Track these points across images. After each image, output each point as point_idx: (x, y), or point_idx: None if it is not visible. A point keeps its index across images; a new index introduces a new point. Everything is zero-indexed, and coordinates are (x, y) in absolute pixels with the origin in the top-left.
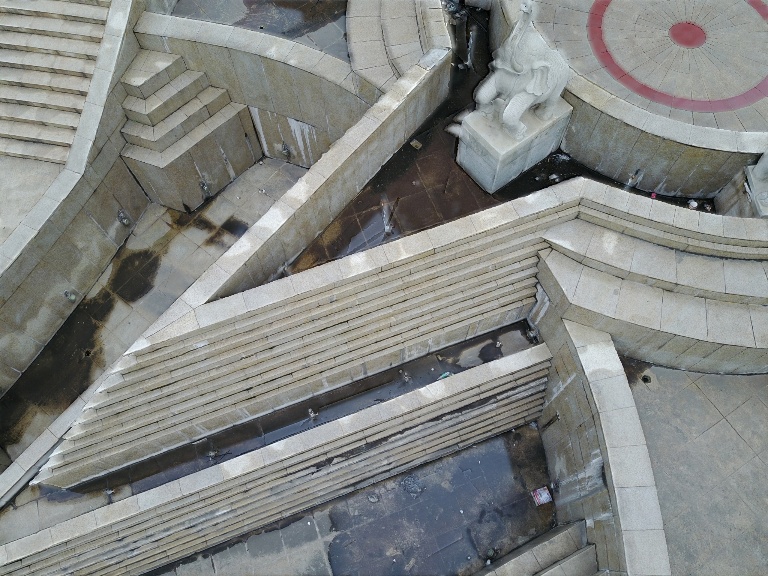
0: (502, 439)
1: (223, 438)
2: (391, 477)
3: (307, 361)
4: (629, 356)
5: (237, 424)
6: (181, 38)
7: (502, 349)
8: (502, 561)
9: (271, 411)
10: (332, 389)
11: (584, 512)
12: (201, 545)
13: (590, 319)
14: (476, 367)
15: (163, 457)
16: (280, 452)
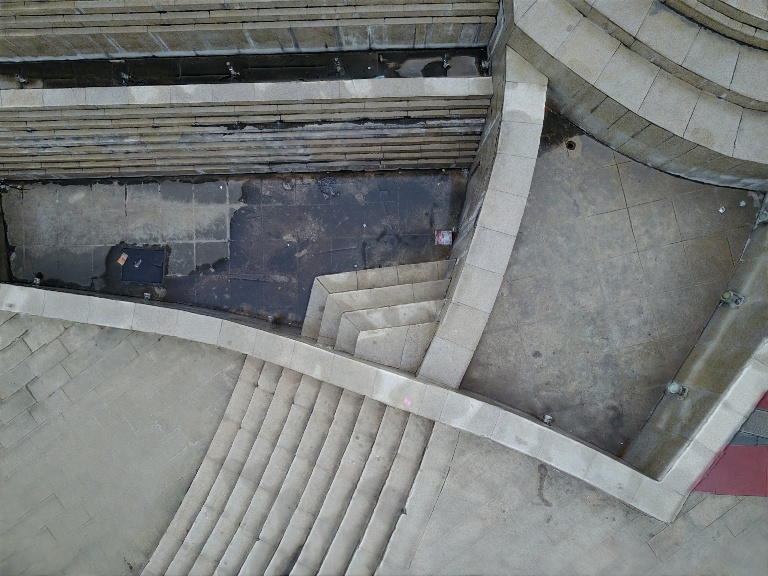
0: (429, 174)
1: (141, 66)
2: (310, 172)
3: (225, 0)
4: (565, 115)
5: (157, 56)
6: None
7: (448, 71)
8: None
9: (193, 54)
10: (261, 53)
11: (459, 252)
12: (114, 169)
13: (532, 52)
14: (410, 78)
15: (79, 64)
16: (188, 95)
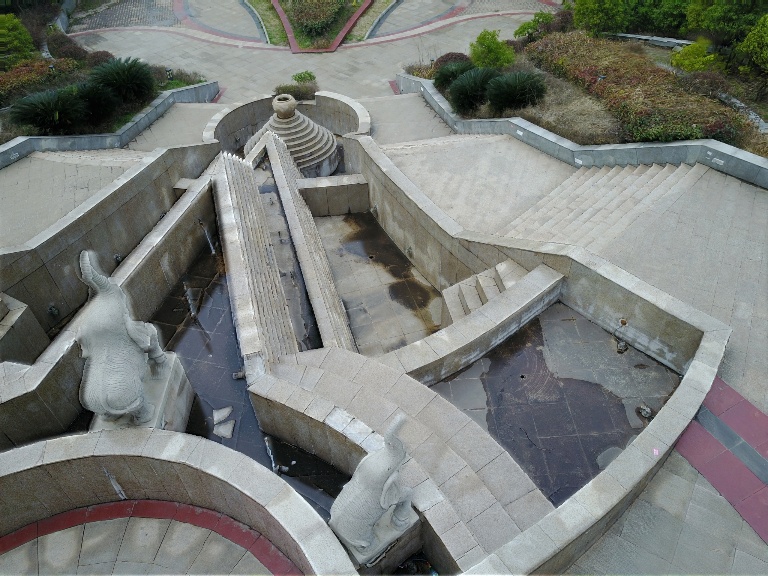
0: None
1: None
2: None
3: None
4: None
5: None
6: (510, 287)
7: None
8: (22, 361)
9: None
10: None
11: None
12: None
13: None
14: None
15: None
16: None
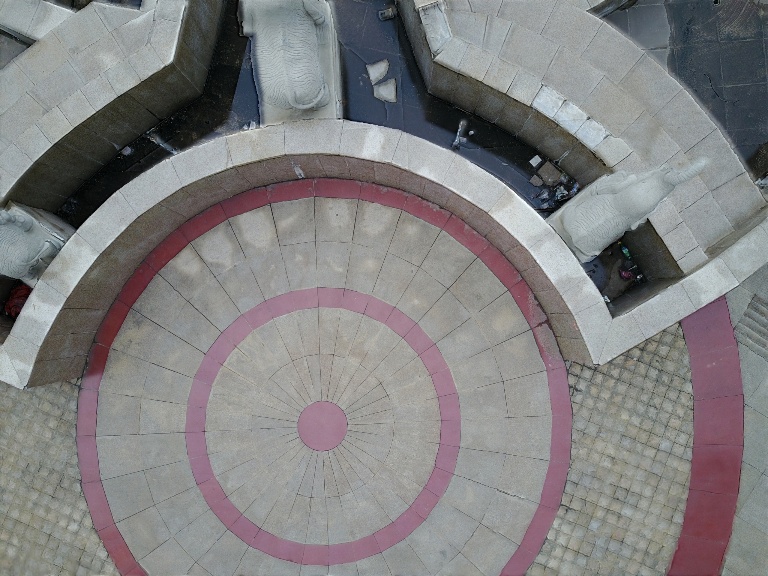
0: None
1: None
2: None
3: None
4: None
5: None
6: None
7: None
8: None
9: None
10: None
11: None
12: None
13: None
14: None
15: None
16: None
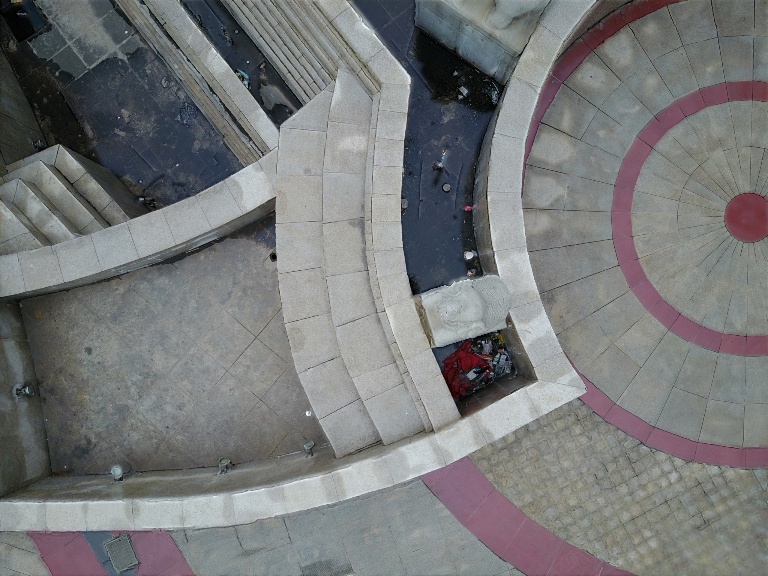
0: None
1: None
2: None
3: None
4: None
5: None
6: None
7: None
8: None
9: None
10: None
11: None
12: None
13: None
14: (253, 97)
15: None
16: None
